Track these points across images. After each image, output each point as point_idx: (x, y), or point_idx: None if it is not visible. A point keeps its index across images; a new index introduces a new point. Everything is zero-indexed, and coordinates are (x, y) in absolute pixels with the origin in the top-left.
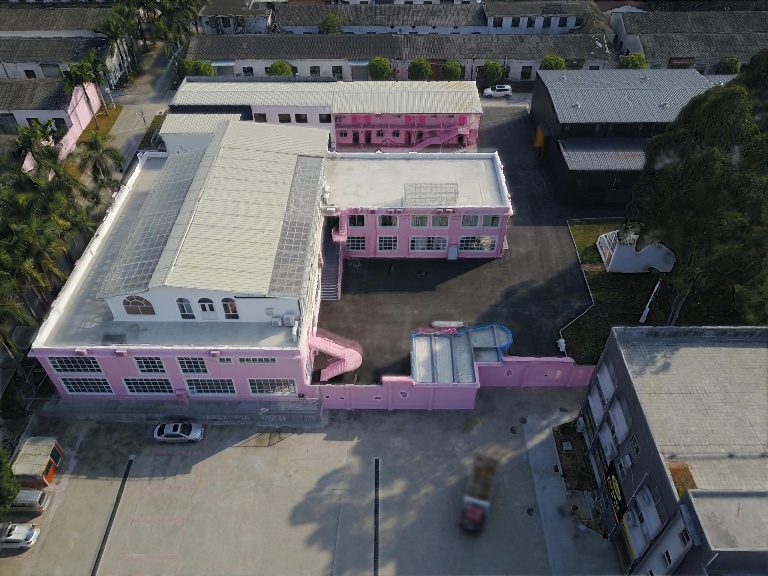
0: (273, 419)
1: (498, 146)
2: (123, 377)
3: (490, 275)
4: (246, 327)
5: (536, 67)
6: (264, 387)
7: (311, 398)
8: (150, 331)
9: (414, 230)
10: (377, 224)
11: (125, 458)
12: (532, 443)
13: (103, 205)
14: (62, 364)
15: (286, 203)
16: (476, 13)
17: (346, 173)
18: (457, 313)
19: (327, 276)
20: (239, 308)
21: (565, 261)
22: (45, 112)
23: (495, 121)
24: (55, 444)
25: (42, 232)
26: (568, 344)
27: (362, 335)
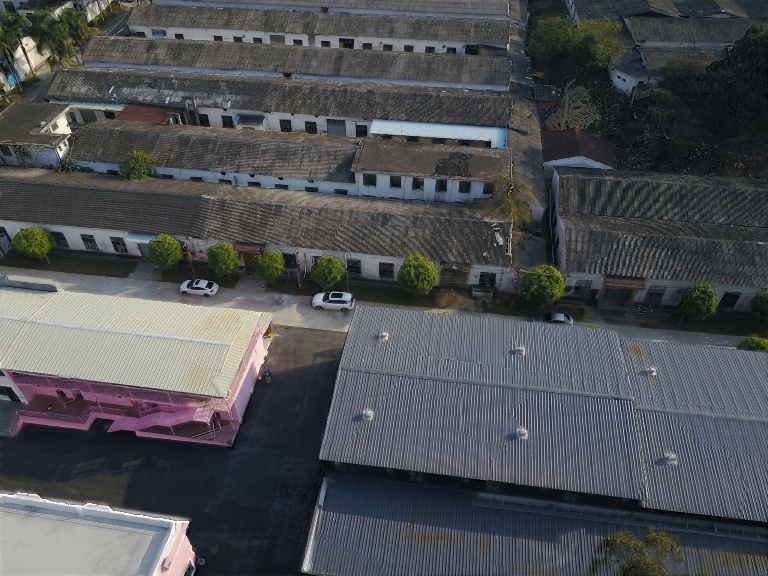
0: None
1: (274, 428)
2: None
3: None
4: None
5: (399, 266)
6: None
7: None
8: None
9: None
10: None
11: None
12: None
13: None
14: None
15: None
16: (344, 161)
17: None
18: None
19: None
20: None
21: None
22: None
23: (300, 365)
24: None
25: None
26: None
27: None
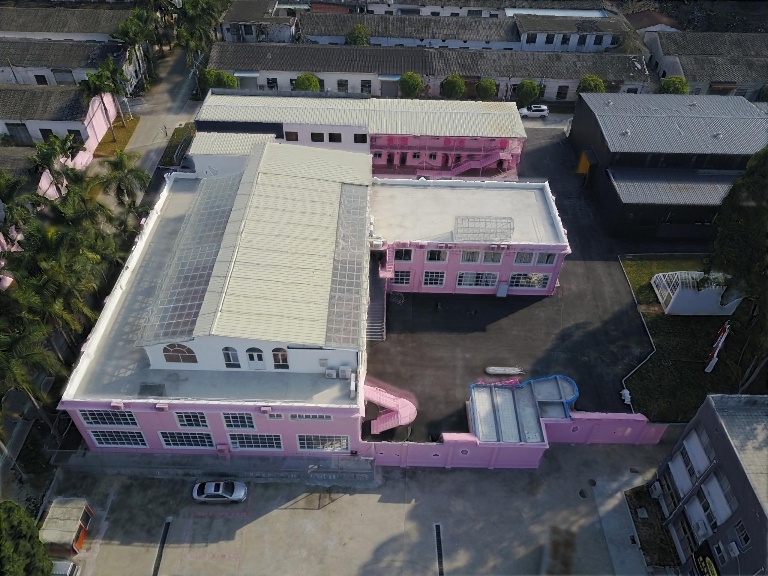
0: (322, 477)
1: (539, 171)
2: (160, 431)
3: (543, 315)
4: (297, 379)
5: (573, 87)
6: (314, 443)
7: (366, 457)
8: (192, 381)
9: (464, 266)
10: (425, 259)
11: (161, 520)
12: (604, 509)
13: (131, 233)
14: (94, 417)
15: (334, 238)
16: (509, 28)
17: (389, 201)
18: (512, 358)
19: (371, 314)
20: (291, 358)
21: (620, 301)
22: (60, 123)
23: (533, 144)
24: (85, 507)
25: (71, 268)
26: (633, 395)
27: (412, 381)
